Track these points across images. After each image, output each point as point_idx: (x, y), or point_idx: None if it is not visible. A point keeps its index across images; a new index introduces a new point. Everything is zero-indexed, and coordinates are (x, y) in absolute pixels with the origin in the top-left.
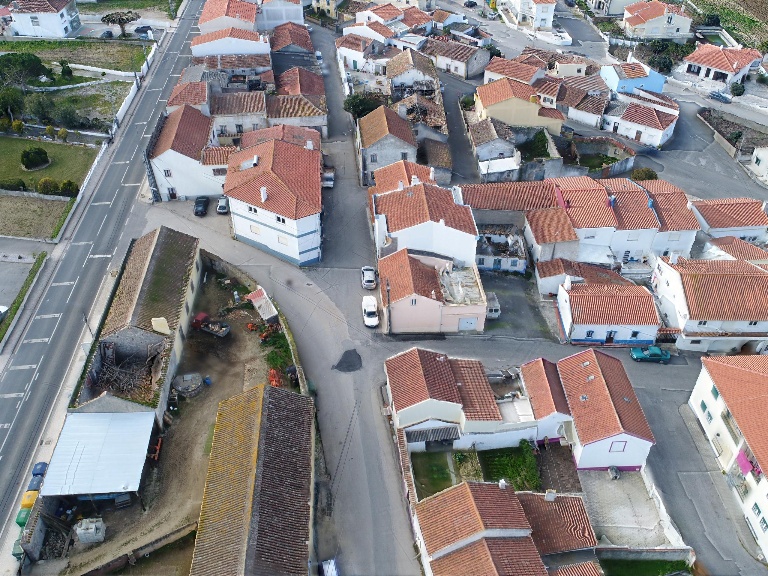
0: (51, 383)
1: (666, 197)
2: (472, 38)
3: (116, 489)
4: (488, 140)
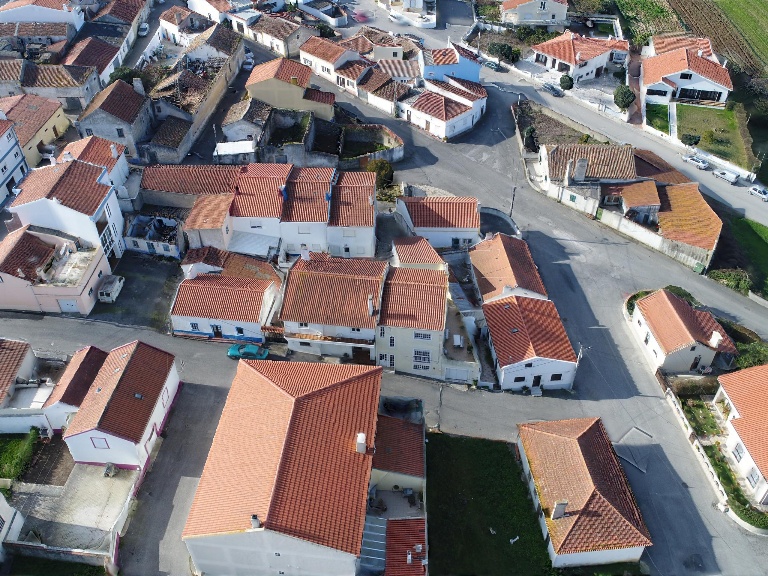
0: None
1: (352, 190)
2: (327, 16)
3: None
4: (233, 121)
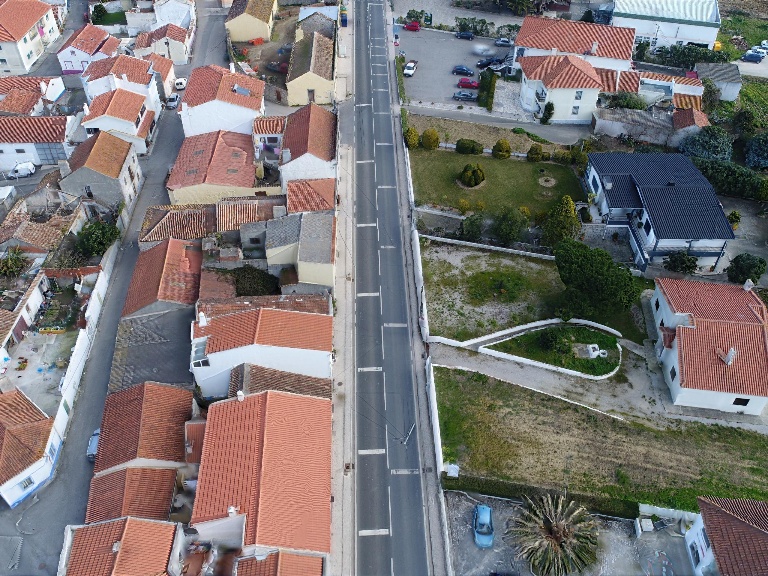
0: (361, 50)
1: None
2: None
3: (309, 7)
4: None
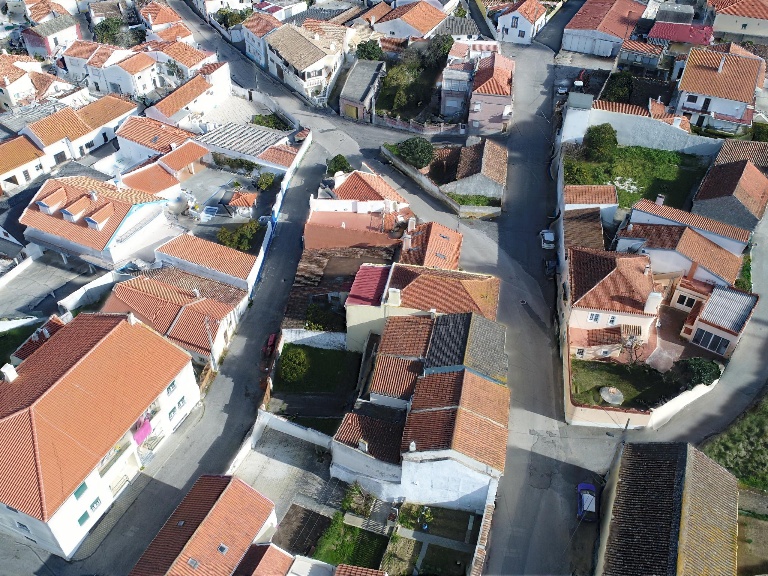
0: None
1: None
2: None
3: None
4: None
